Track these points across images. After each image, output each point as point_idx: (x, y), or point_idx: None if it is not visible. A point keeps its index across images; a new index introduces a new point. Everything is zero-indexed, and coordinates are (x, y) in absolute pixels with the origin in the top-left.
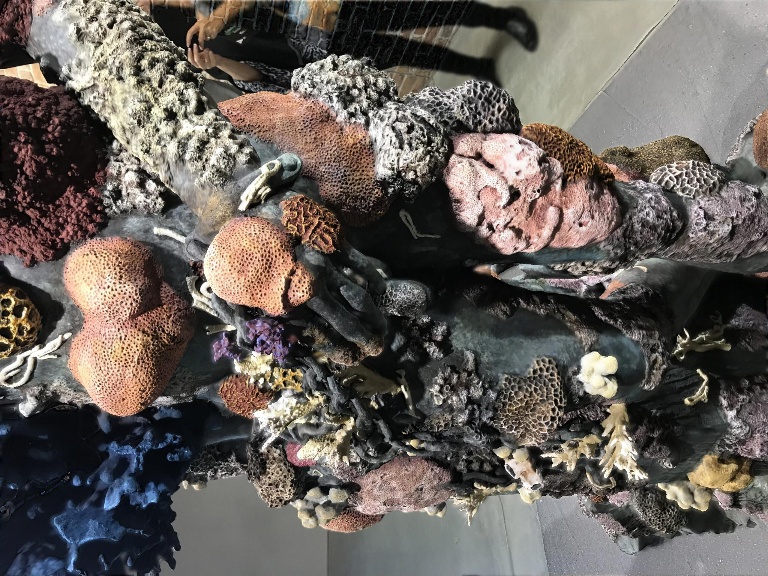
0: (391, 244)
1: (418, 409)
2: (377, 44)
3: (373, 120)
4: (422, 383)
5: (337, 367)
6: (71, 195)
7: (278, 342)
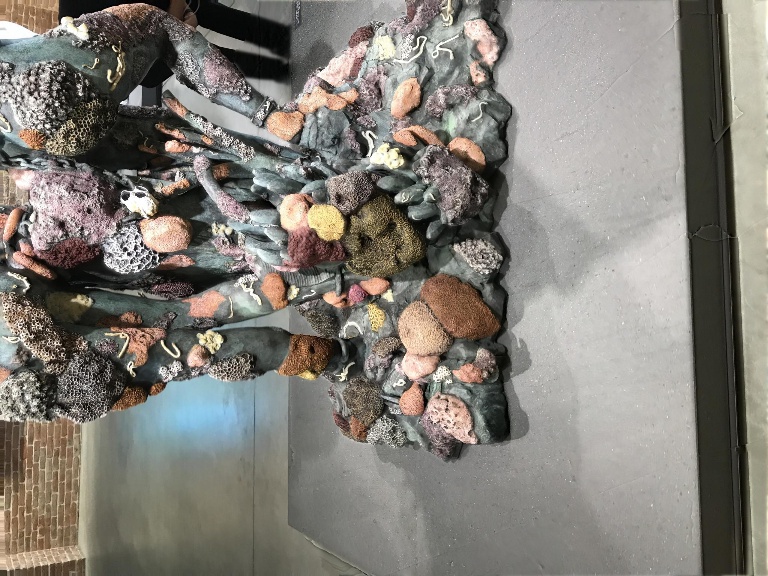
0: None
1: None
2: None
3: None
4: None
5: None
6: None
7: None
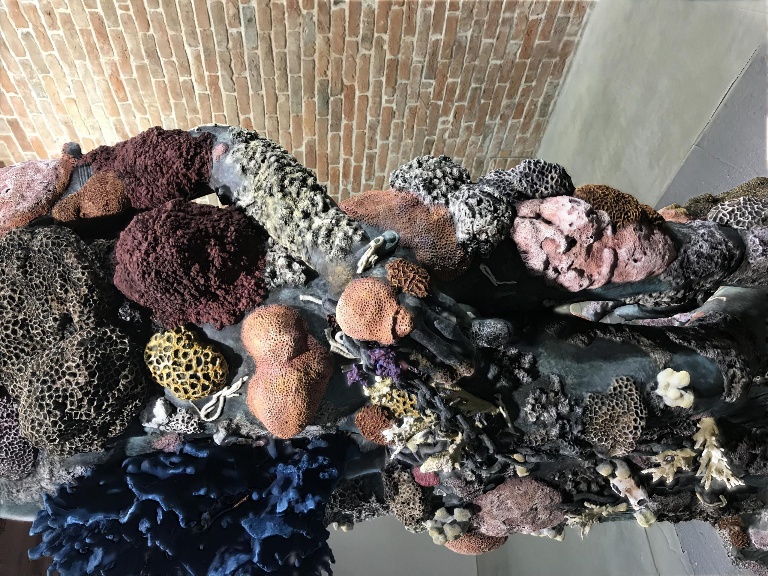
0: (477, 292)
1: (516, 427)
2: (479, 133)
3: (451, 200)
4: (517, 404)
5: (443, 391)
6: (244, 278)
7: (392, 365)
